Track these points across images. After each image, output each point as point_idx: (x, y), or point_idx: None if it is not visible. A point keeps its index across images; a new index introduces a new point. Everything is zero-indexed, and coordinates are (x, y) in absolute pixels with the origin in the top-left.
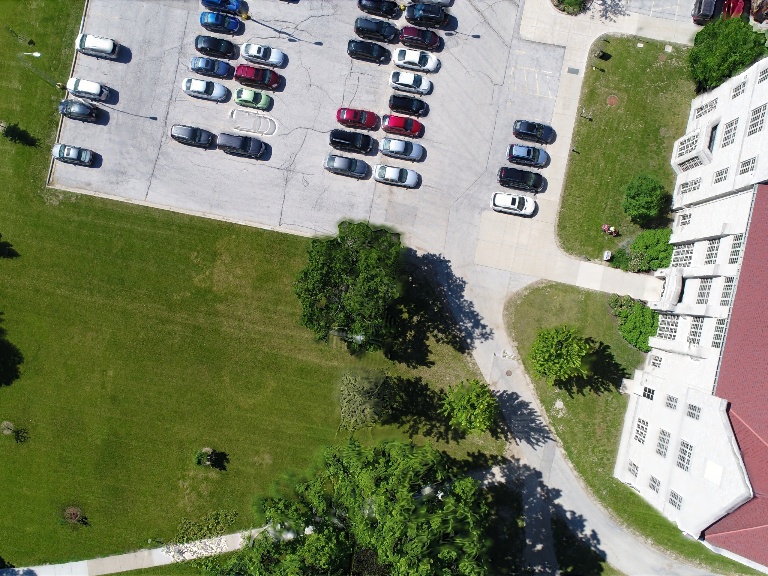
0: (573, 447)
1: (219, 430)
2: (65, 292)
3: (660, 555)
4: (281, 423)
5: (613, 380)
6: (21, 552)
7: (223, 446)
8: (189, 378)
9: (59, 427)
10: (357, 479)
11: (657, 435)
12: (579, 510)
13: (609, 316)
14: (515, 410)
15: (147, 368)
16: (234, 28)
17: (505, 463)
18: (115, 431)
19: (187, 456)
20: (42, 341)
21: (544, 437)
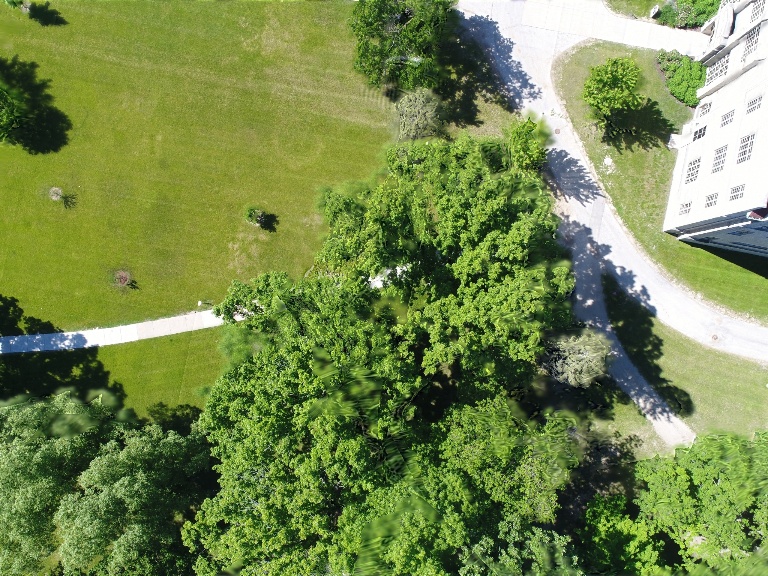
0: (622, 203)
1: (268, 192)
2: (113, 59)
3: (710, 310)
4: (331, 184)
5: (661, 136)
6: (70, 317)
7: (273, 208)
8: (238, 142)
9: (108, 192)
10: (423, 163)
11: (712, 158)
12: (629, 266)
13: (656, 73)
14: (564, 167)
15: (196, 132)
16: None
17: (555, 220)
18: (164, 195)
19: (237, 219)
20: (90, 108)
21: (593, 193)
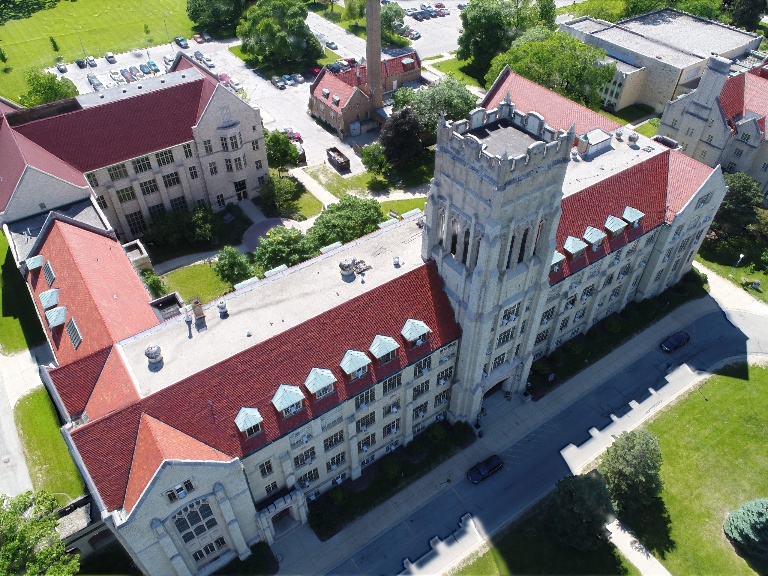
0: None
1: None
2: None
3: None
4: None
5: None
6: None
7: None
8: None
9: None
10: None
11: None
12: None
13: None
14: None
15: None
16: (145, 70)
17: None
18: None
19: None
20: None
21: None
